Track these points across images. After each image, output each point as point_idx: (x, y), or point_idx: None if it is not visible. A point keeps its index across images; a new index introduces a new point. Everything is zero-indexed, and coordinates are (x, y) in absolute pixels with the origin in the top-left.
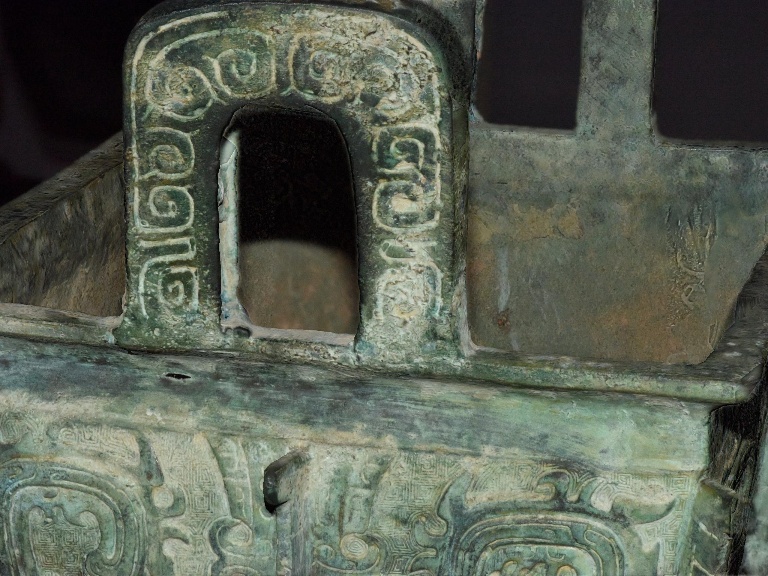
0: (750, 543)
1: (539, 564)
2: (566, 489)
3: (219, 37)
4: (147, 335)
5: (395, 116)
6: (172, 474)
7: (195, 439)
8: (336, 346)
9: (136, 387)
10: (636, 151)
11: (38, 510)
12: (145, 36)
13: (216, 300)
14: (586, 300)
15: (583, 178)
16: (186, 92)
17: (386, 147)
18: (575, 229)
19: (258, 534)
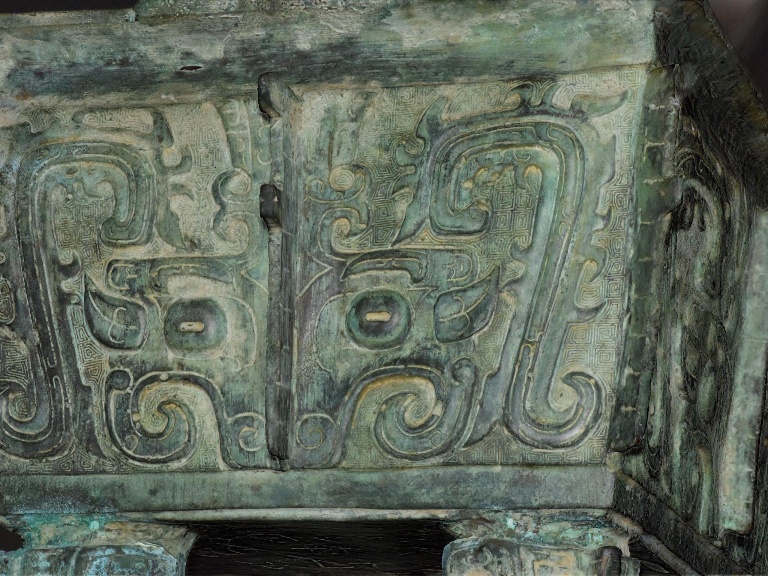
0: (739, 397)
1: (508, 168)
2: (530, 96)
3: None
4: (163, 4)
5: None
6: (181, 137)
7: (203, 106)
8: None
9: (154, 81)
10: None
11: (61, 190)
12: None
13: None
14: None
15: None
16: None
17: None
18: None
19: (256, 179)
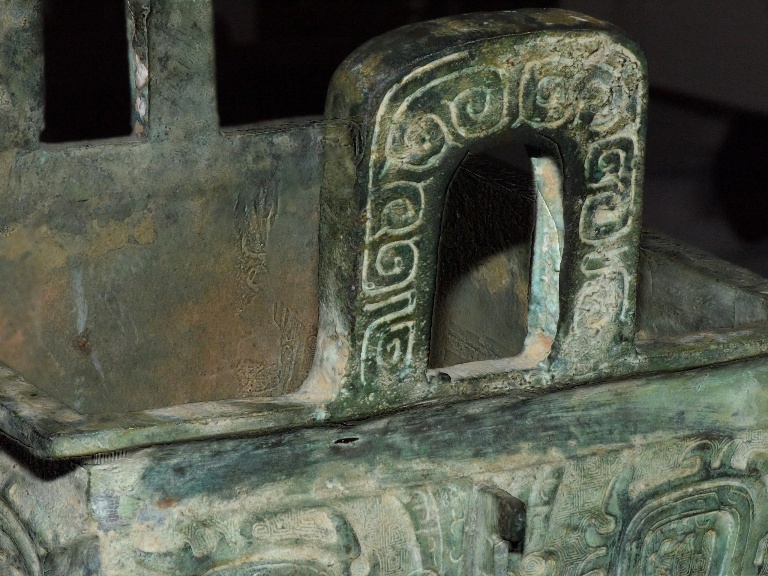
0: None
1: (688, 535)
2: None
3: (458, 78)
4: (362, 402)
5: (606, 130)
6: (367, 542)
7: (383, 500)
8: (530, 370)
9: (308, 462)
10: (207, 145)
11: None
12: (390, 89)
13: (428, 350)
14: (160, 303)
15: (160, 181)
16: (424, 141)
17: (596, 162)
18: (150, 234)
19: None
